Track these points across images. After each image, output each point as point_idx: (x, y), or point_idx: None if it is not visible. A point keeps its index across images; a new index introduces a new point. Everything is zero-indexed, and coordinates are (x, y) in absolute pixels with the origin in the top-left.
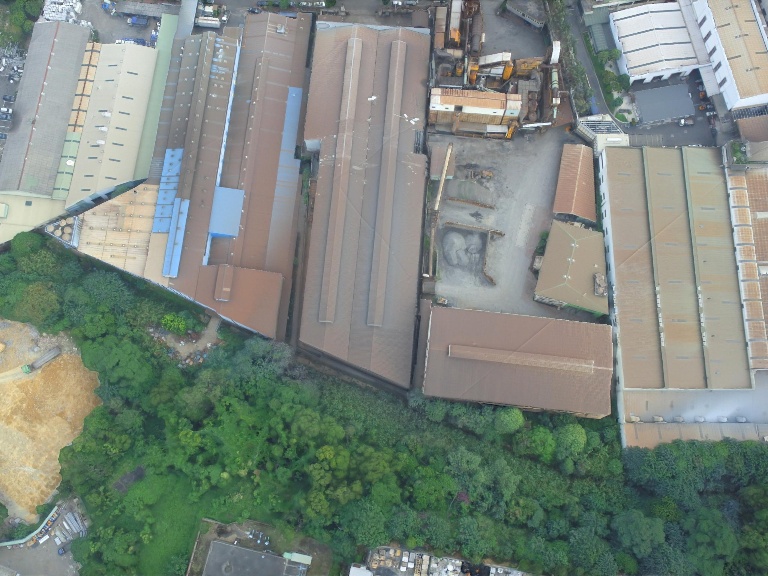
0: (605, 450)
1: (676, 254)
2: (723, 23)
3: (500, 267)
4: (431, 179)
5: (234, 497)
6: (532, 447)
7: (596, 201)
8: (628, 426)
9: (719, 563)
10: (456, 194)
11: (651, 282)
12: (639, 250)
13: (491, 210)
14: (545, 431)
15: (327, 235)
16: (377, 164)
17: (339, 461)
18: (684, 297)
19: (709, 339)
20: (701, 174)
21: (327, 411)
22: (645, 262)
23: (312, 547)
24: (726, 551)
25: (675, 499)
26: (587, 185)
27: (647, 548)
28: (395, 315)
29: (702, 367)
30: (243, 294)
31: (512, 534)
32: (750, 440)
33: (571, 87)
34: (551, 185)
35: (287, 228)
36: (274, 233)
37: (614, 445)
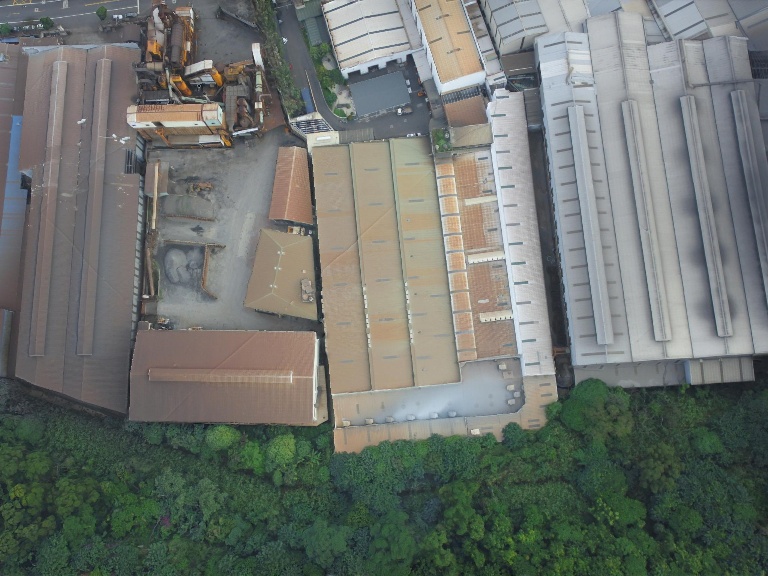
0: (315, 458)
1: (384, 251)
2: (424, 5)
3: (221, 280)
4: (151, 197)
5: None
6: (243, 462)
7: (314, 203)
8: (338, 432)
9: (400, 567)
10: (174, 210)
11: (360, 283)
12: (347, 251)
13: (211, 222)
14: (254, 445)
15: (36, 267)
16: (86, 189)
17: (28, 499)
18: (391, 295)
19: (415, 336)
20: (409, 165)
21: (50, 444)
22: (353, 263)
23: None
24: (400, 555)
25: (366, 504)
26: (302, 188)
27: (328, 558)
28: (108, 341)
29: (410, 365)
30: None
31: (211, 553)
32: (454, 435)
33: (278, 88)
34: (271, 190)
35: (15, 261)
36: (2, 268)
37: (326, 452)
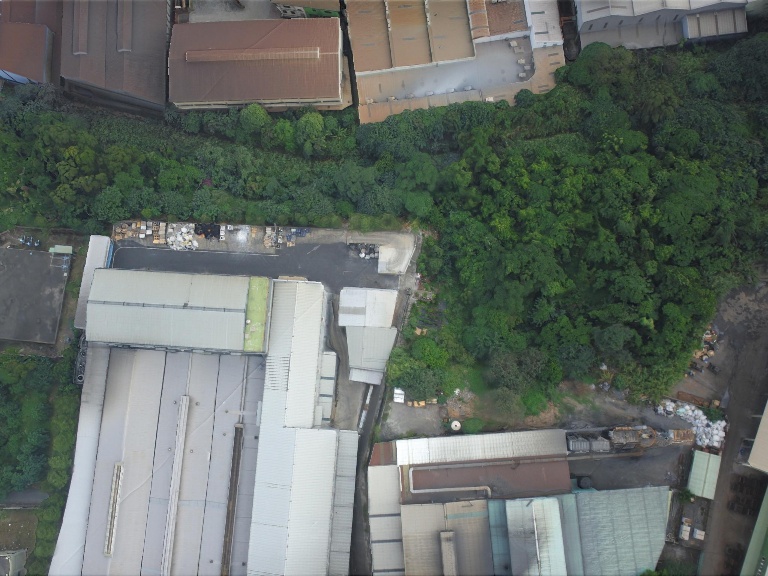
0: (342, 131)
1: None
2: None
3: None
4: None
5: (4, 210)
6: (275, 138)
7: None
8: (362, 107)
9: (424, 194)
10: None
11: None
12: None
13: None
14: (285, 121)
15: None
16: None
17: (82, 156)
18: None
19: (432, 18)
20: None
21: None
22: None
23: (77, 243)
24: (424, 179)
25: (391, 152)
26: None
27: (358, 190)
28: (145, 41)
29: (428, 45)
30: (9, 45)
31: None
32: None
33: None
34: None
35: None
36: None
37: (352, 127)
